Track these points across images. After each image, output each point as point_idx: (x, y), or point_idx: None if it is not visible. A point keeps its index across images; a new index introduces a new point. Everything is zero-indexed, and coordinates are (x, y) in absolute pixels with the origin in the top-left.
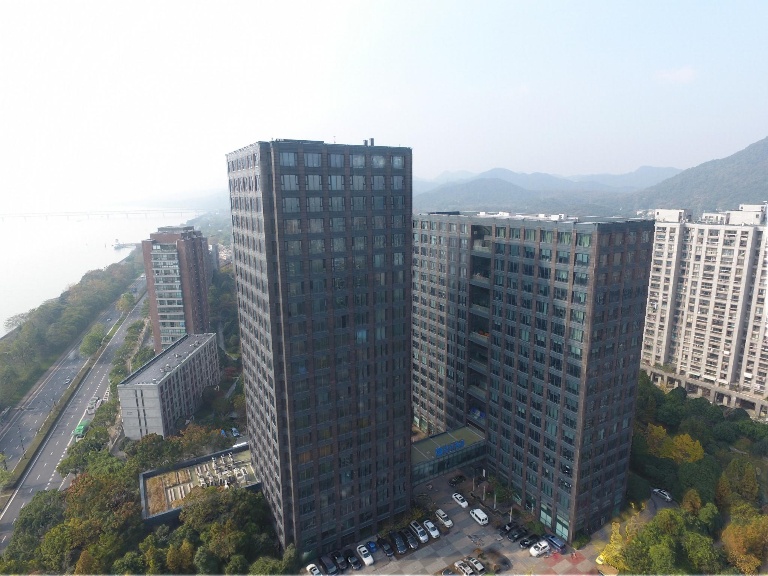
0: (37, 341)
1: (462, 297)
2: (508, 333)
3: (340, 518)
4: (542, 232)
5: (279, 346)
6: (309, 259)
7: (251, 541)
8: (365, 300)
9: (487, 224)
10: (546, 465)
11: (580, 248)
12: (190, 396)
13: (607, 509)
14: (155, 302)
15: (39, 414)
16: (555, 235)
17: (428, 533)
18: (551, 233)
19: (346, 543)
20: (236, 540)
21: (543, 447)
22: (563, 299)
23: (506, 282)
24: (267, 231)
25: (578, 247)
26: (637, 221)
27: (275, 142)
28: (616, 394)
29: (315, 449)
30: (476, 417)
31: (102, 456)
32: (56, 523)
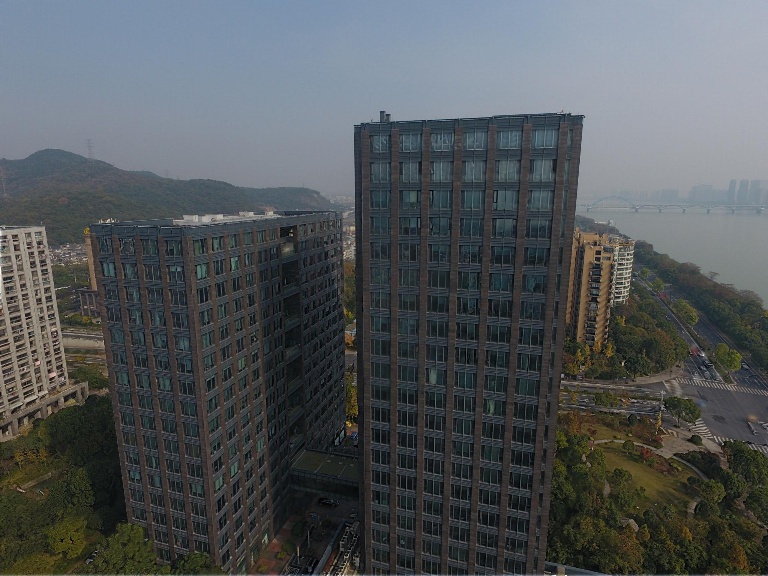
0: None
1: (277, 321)
2: None
3: None
4: (323, 223)
5: None
6: None
7: None
8: None
9: (293, 224)
10: None
11: None
12: None
13: None
14: None
15: None
16: None
17: None
18: None
19: None
20: None
21: None
22: None
23: None
24: None
25: None
26: None
27: None
28: None
29: None
30: (292, 445)
31: None
32: None
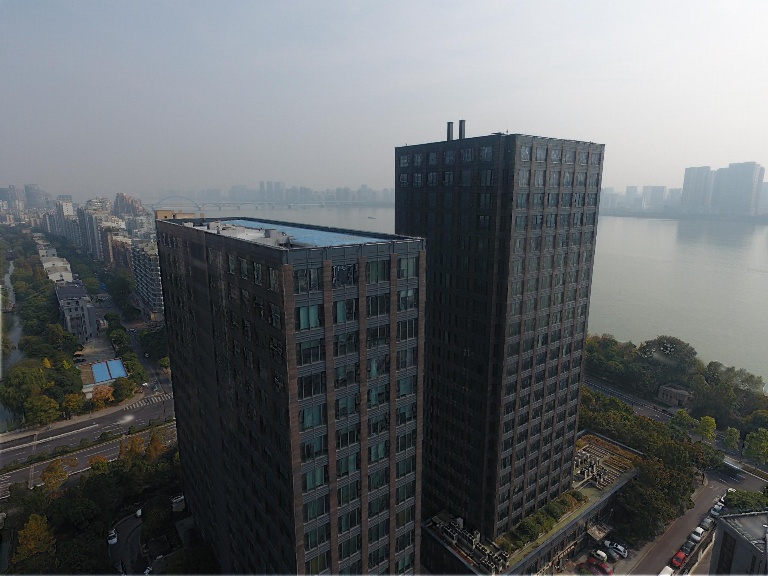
0: None
1: None
2: None
3: None
4: None
5: None
6: None
7: None
8: None
9: None
10: None
11: None
12: None
13: None
14: None
15: None
16: None
17: None
18: None
19: None
20: None
21: None
22: None
23: None
24: None
25: None
26: None
27: None
28: None
29: None
30: None
31: (767, 501)
32: None
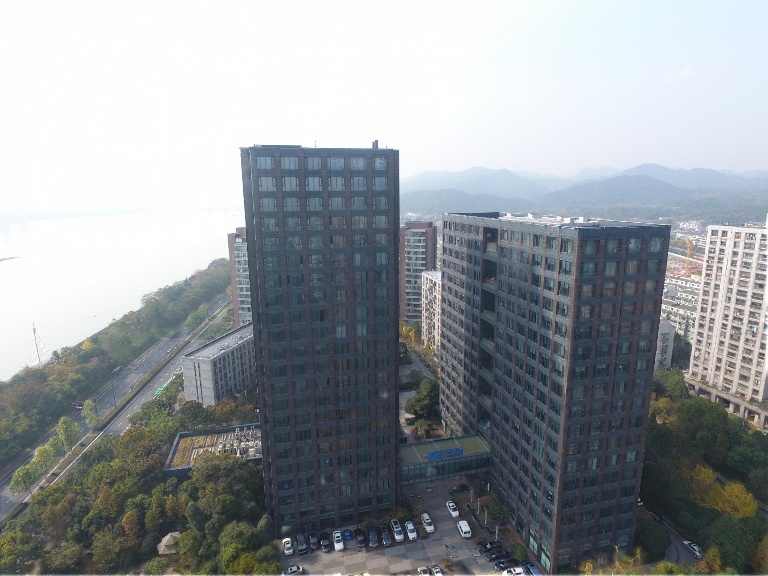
0: (155, 315)
1: (476, 301)
2: (508, 342)
3: (319, 501)
4: (535, 236)
5: (260, 333)
6: (286, 255)
7: (240, 506)
8: (345, 297)
9: (495, 226)
10: (534, 488)
11: (564, 255)
12: (247, 374)
13: (606, 549)
14: (236, 288)
15: (140, 375)
16: (544, 240)
17: (405, 534)
18: (542, 237)
19: (326, 526)
20: (224, 502)
21: (532, 468)
22: (551, 310)
23: (507, 288)
24: (248, 228)
25: (562, 254)
26: (639, 227)
27: (252, 148)
28: (615, 421)
29: (293, 432)
30: (485, 427)
31: (163, 414)
32: (108, 461)
